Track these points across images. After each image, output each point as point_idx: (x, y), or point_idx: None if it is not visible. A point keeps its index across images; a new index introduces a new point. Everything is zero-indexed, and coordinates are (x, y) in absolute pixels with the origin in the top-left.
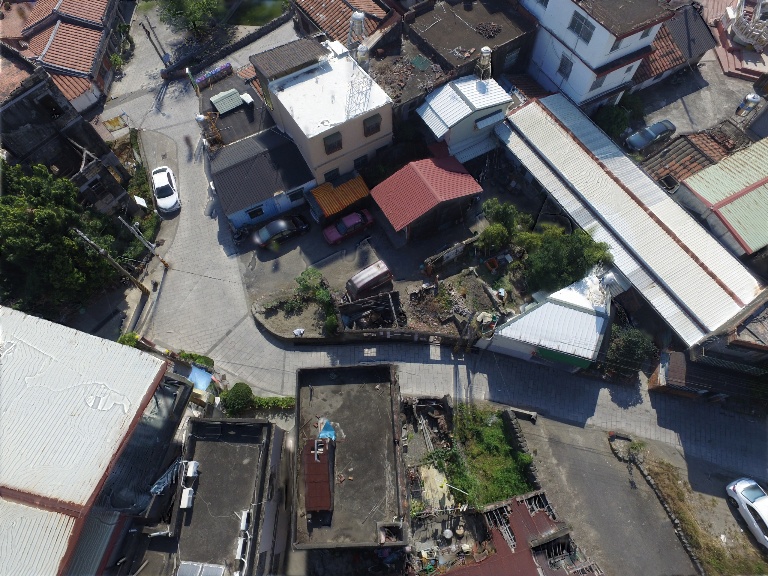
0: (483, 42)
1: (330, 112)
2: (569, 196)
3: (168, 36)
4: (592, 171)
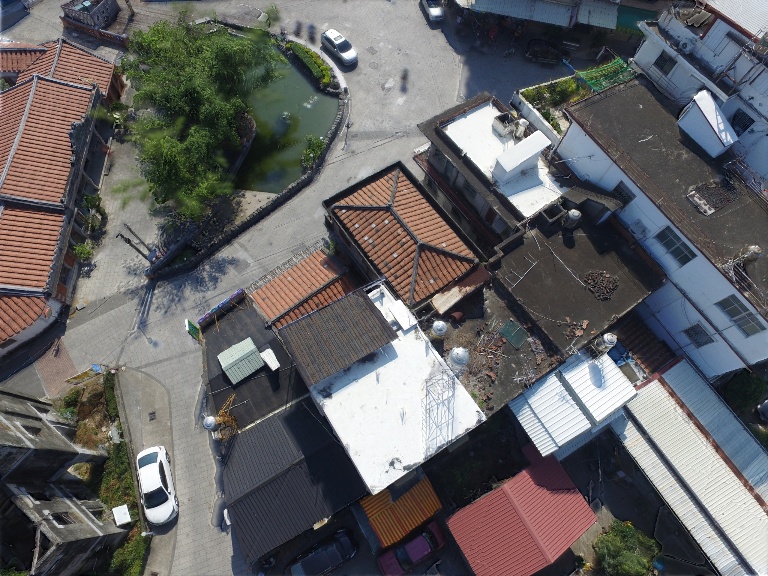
0: (596, 307)
1: (401, 442)
2: (716, 540)
3: (152, 202)
4: (746, 507)
